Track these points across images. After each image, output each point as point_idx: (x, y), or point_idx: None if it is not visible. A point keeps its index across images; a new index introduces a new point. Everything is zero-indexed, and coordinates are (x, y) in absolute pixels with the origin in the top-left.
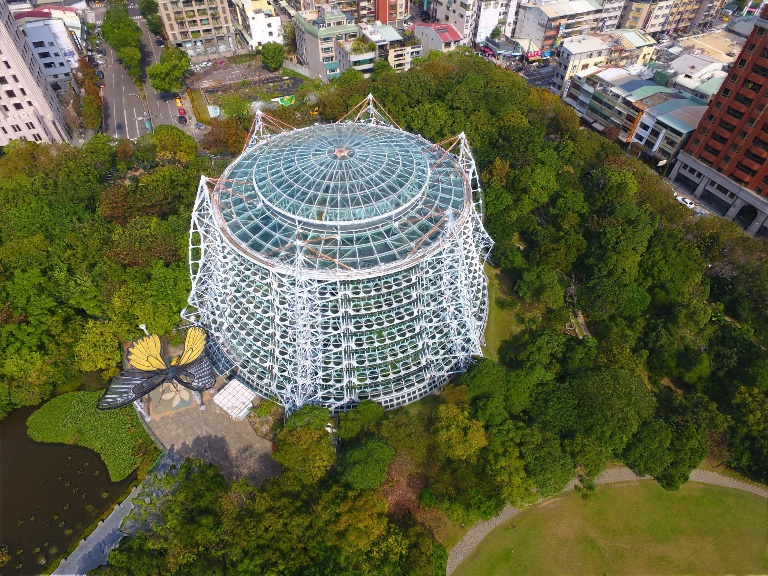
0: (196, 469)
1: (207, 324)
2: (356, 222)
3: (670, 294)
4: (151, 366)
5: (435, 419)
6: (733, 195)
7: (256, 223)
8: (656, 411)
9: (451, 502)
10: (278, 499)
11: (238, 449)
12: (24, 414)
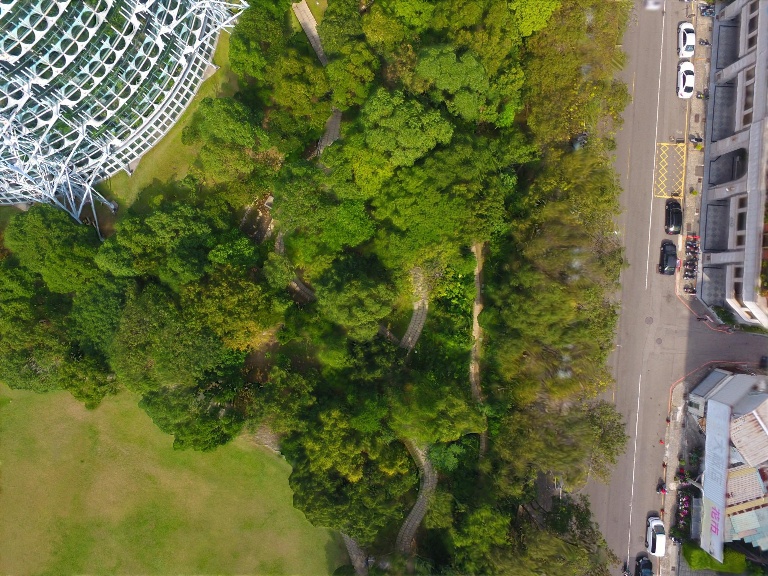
0: None
1: None
2: None
3: (389, 249)
4: None
5: None
6: (750, 119)
7: None
8: (275, 359)
9: None
10: None
11: None
12: None
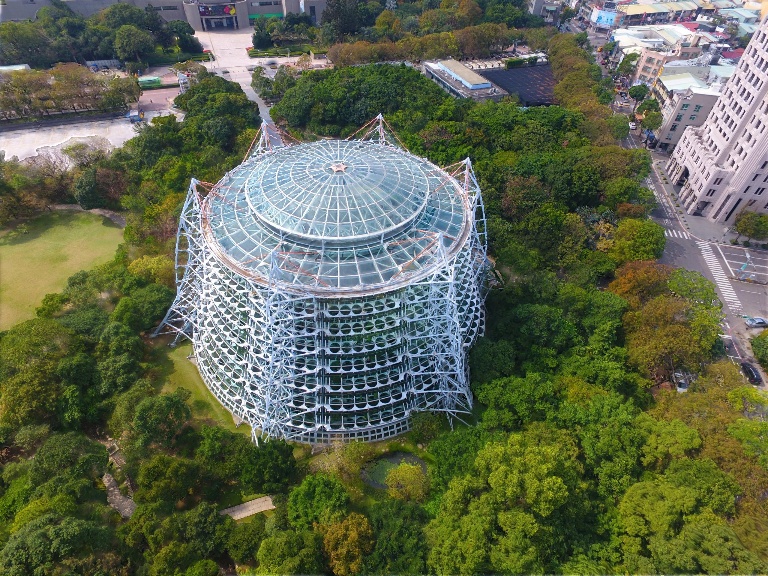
0: None
1: None
2: None
3: None
4: None
5: None
6: None
7: None
8: None
9: None
10: (215, 182)
11: None
12: None
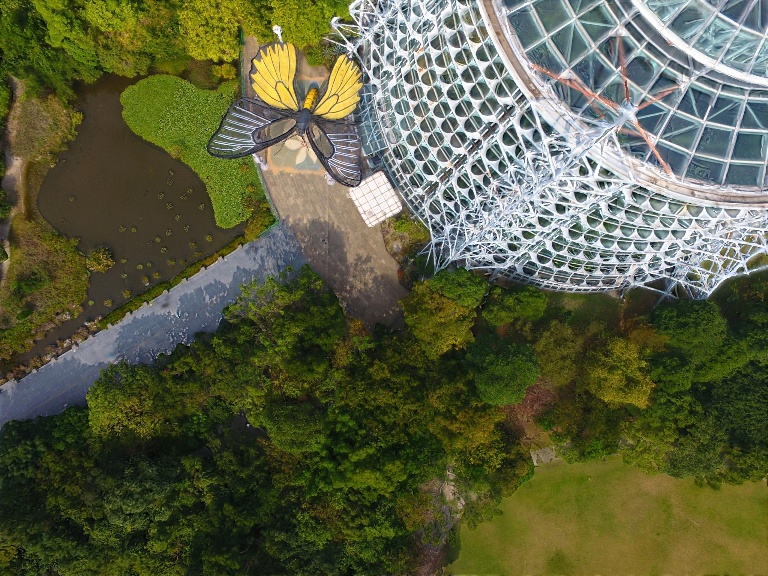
0: (315, 291)
1: (363, 48)
2: (751, 80)
3: None
4: (279, 100)
5: (600, 343)
6: None
7: None
8: None
9: (566, 437)
10: (396, 374)
11: (360, 256)
12: (117, 84)
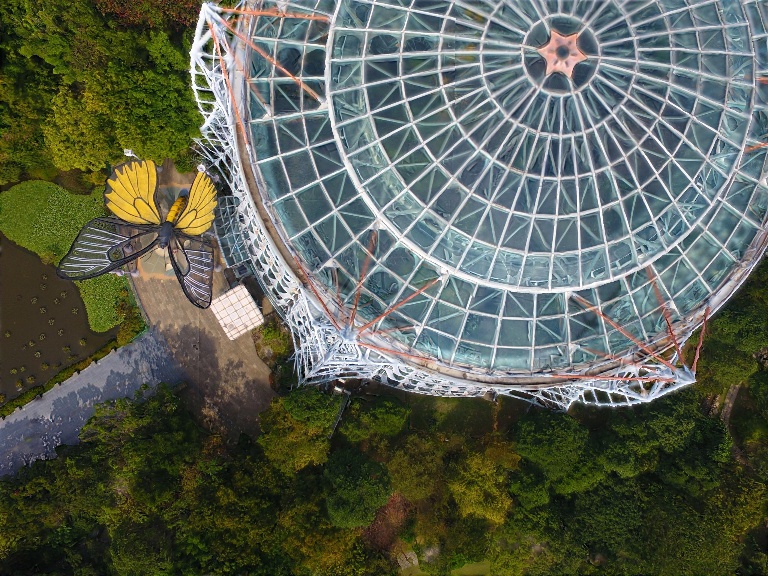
0: (165, 413)
1: None
2: (492, 285)
3: None
4: (138, 216)
5: (463, 454)
6: None
7: (306, 152)
8: None
9: (429, 549)
10: (244, 498)
11: (231, 361)
12: None
